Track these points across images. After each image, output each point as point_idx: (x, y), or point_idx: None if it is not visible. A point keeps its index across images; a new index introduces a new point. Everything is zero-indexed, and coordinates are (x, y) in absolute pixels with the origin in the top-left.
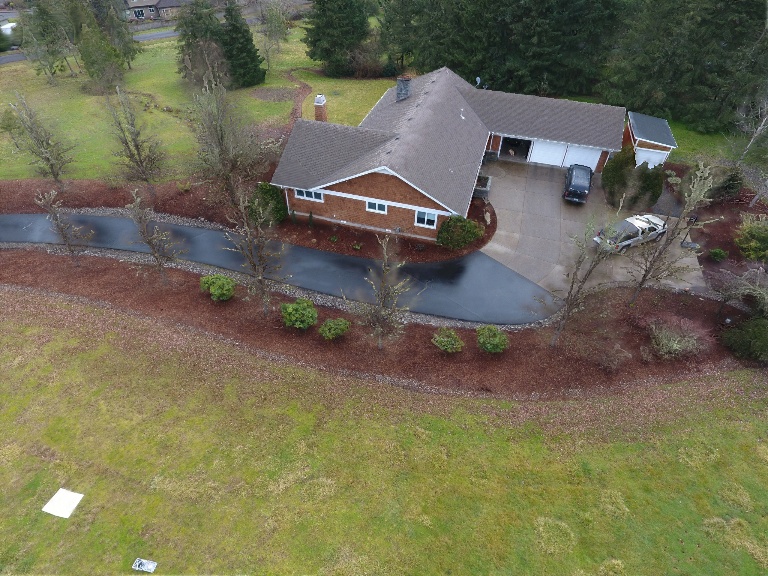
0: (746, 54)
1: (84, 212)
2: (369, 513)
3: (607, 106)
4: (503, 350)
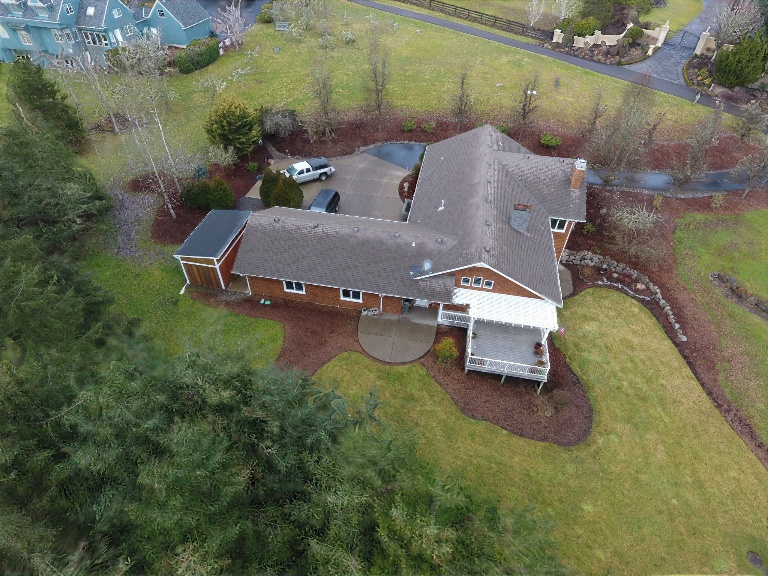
0: (2, 233)
1: (704, 193)
2: (447, 92)
3: (271, 215)
4: (402, 131)
